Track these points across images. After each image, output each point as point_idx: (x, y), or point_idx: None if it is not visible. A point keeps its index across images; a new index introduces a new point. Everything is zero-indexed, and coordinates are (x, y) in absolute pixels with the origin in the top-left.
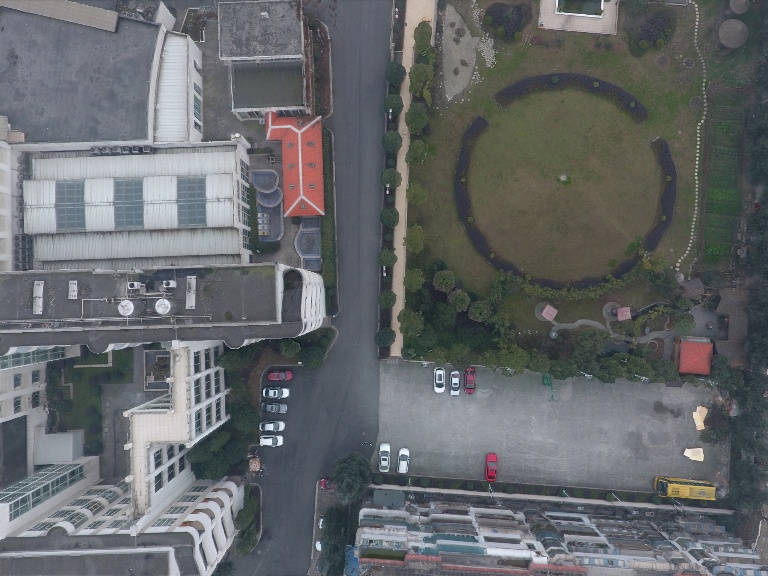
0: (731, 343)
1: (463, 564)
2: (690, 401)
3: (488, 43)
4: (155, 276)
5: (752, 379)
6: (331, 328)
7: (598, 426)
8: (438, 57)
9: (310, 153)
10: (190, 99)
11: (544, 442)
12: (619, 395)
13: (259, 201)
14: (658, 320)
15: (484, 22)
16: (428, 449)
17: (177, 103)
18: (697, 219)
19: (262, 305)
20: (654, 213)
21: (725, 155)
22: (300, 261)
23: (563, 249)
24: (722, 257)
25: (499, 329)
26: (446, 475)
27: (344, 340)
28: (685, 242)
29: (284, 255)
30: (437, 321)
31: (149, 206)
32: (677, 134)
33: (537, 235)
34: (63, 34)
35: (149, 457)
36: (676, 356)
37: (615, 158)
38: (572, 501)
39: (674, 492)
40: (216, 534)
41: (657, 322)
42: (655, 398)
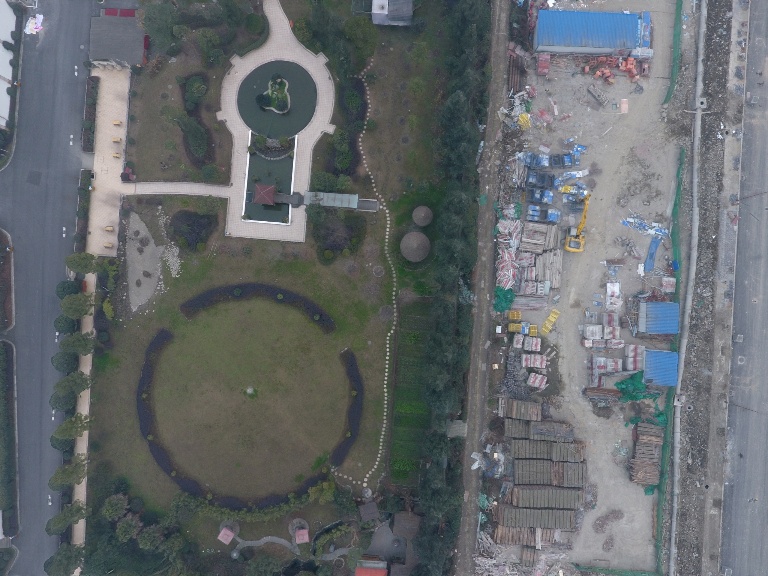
0: (406, 569)
1: None
2: None
3: (173, 252)
4: None
5: None
6: (11, 548)
7: None
8: (120, 268)
9: None
10: None
11: None
12: None
13: None
14: (345, 537)
15: None
16: None
17: None
18: (386, 432)
19: None
20: (342, 426)
21: (414, 367)
22: None
23: (249, 464)
24: (410, 472)
25: (169, 557)
26: None
27: (25, 559)
28: (373, 456)
29: None
30: None
31: None
32: (366, 344)
33: (223, 450)
34: None
35: None
36: None
37: (303, 370)
38: None
39: None
40: None
41: (344, 539)
42: None
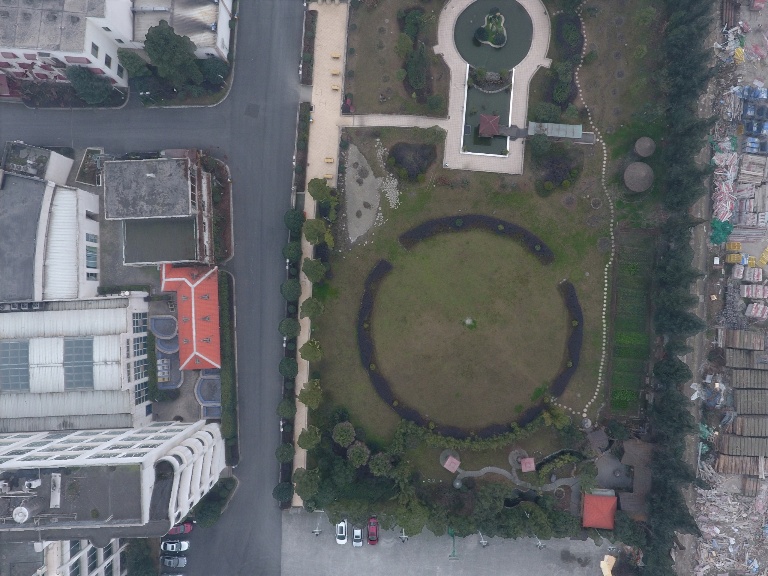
0: (635, 496)
1: None
2: (598, 550)
3: (392, 184)
4: (20, 473)
5: (653, 539)
6: (232, 478)
7: (504, 575)
8: (340, 199)
9: (204, 306)
10: (80, 254)
11: None
12: (525, 544)
13: (158, 348)
14: (565, 467)
15: (388, 162)
16: None
17: (67, 258)
18: (605, 363)
19: (129, 502)
20: (561, 357)
21: (633, 298)
22: (200, 409)
23: (468, 395)
24: (630, 402)
25: (399, 484)
26: None
27: (245, 490)
28: (592, 387)
29: (184, 402)
30: None
31: (35, 369)
32: (584, 276)
33: (442, 380)
34: None
35: None
36: (582, 506)
37: (521, 301)
38: None
39: None
40: None
41: (564, 469)
42: (562, 547)
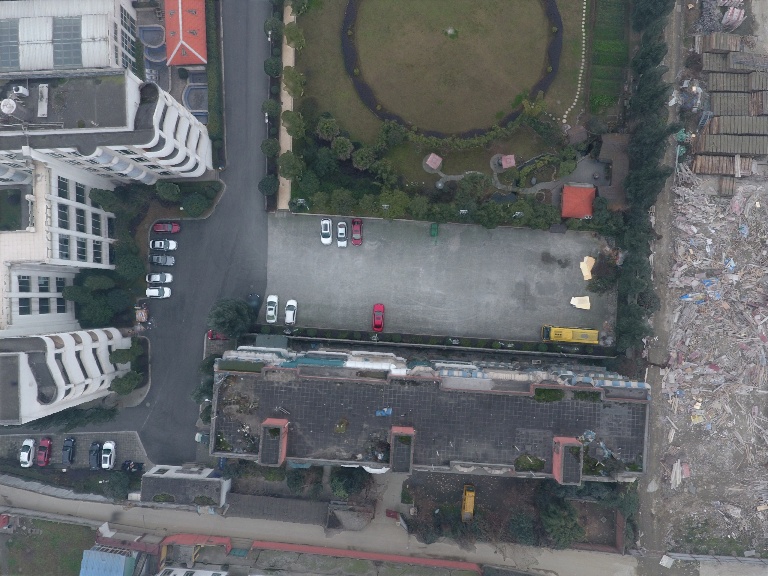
0: (614, 188)
1: (322, 376)
2: (577, 251)
3: None
4: (8, 86)
5: (630, 217)
6: (219, 181)
7: (486, 277)
8: None
9: None
10: None
11: (432, 293)
12: (507, 246)
13: (146, 56)
14: (545, 171)
15: None
16: (316, 301)
17: None
18: (584, 71)
19: (115, 113)
20: (541, 65)
21: (612, 7)
22: None
23: (451, 102)
24: (609, 108)
25: (382, 175)
26: (334, 327)
27: (232, 194)
28: (572, 94)
29: None
30: None
31: (25, 46)
32: None
33: (425, 88)
34: None
35: (10, 276)
36: None
37: (502, 11)
38: (457, 347)
39: (557, 335)
40: (84, 359)
41: (544, 173)
42: (543, 249)
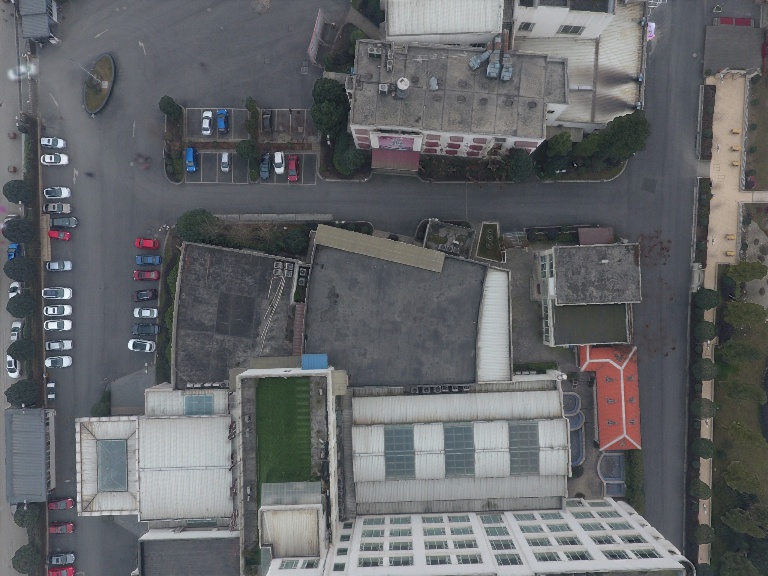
0: None
1: None
2: None
3: None
4: (551, 575)
5: None
6: None
7: None
8: None
9: (630, 388)
10: None
11: None
12: None
13: None
14: None
15: None
16: None
17: (498, 340)
18: None
19: None
20: None
21: None
22: (603, 486)
23: None
24: None
25: None
26: None
27: None
28: None
29: (586, 479)
30: (760, 561)
31: (481, 454)
32: None
33: None
34: (385, 272)
35: None
36: None
37: None
38: None
39: None
40: None
41: None
42: None
